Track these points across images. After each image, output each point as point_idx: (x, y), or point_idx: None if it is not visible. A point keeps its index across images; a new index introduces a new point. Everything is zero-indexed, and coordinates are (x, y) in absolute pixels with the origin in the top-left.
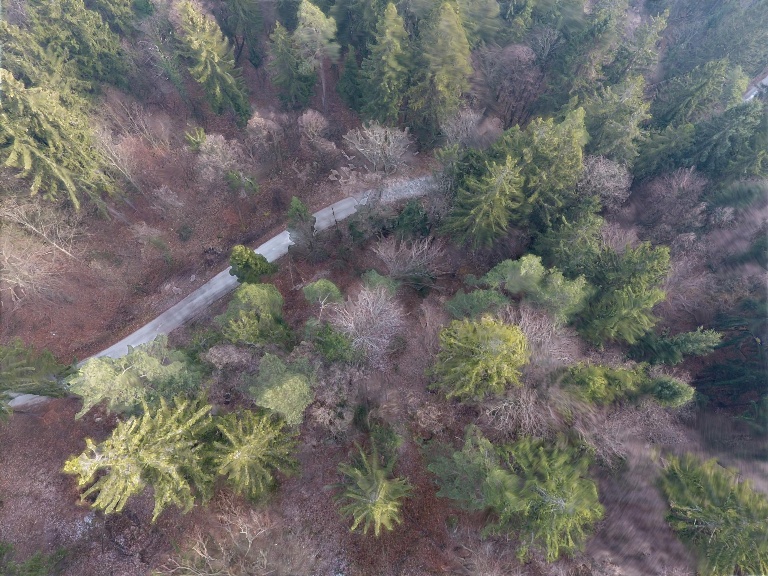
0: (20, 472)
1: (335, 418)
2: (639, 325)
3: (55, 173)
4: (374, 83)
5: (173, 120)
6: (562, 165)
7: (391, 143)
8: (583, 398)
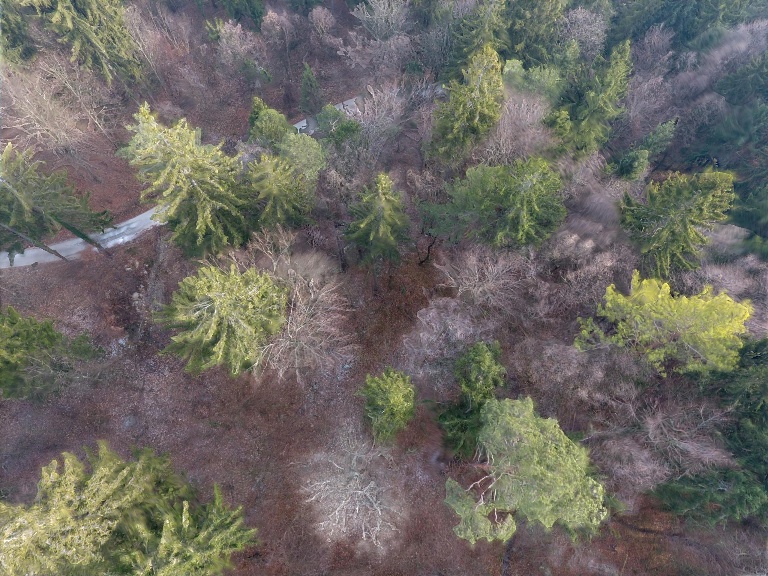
0: (59, 310)
1: (345, 183)
2: (606, 119)
3: (90, 48)
4: None
5: None
6: (544, 7)
7: (394, 10)
8: (555, 159)
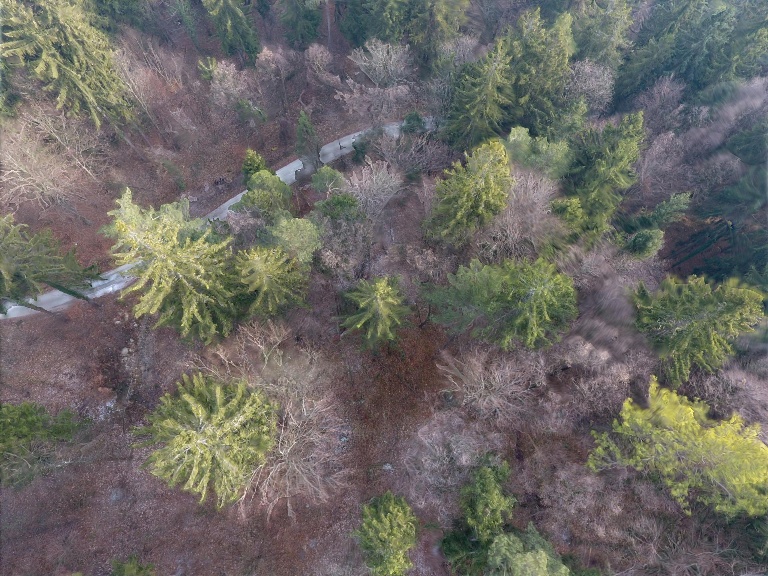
0: (45, 368)
1: (342, 263)
2: (617, 189)
3: (78, 92)
4: (377, 15)
5: (184, 68)
6: (550, 62)
7: (393, 57)
8: (564, 240)
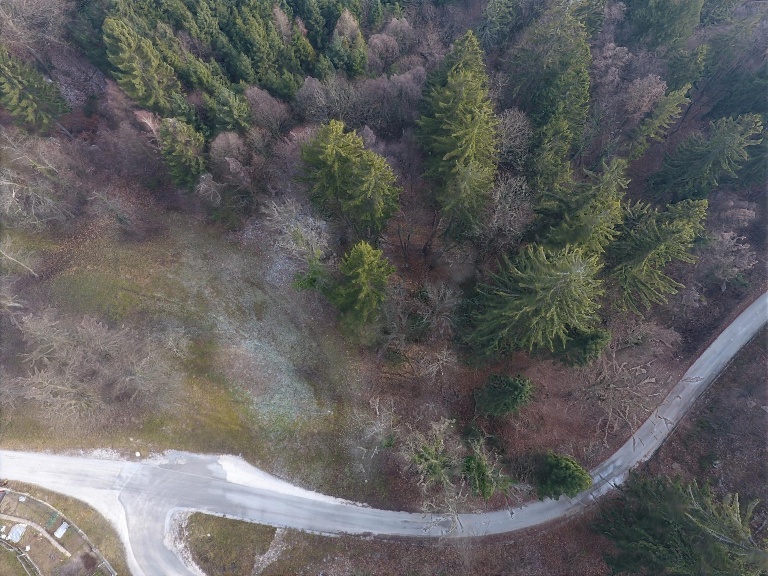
0: None
1: None
2: None
3: None
4: None
5: None
6: None
7: None
8: None
